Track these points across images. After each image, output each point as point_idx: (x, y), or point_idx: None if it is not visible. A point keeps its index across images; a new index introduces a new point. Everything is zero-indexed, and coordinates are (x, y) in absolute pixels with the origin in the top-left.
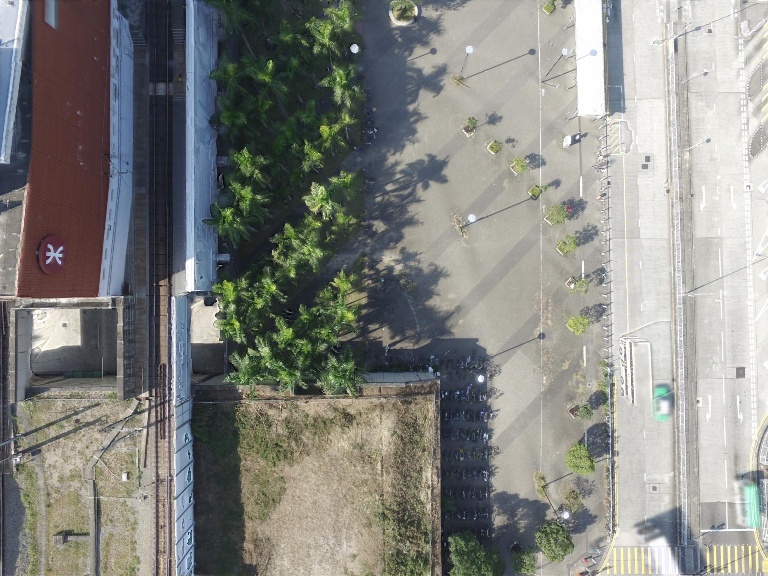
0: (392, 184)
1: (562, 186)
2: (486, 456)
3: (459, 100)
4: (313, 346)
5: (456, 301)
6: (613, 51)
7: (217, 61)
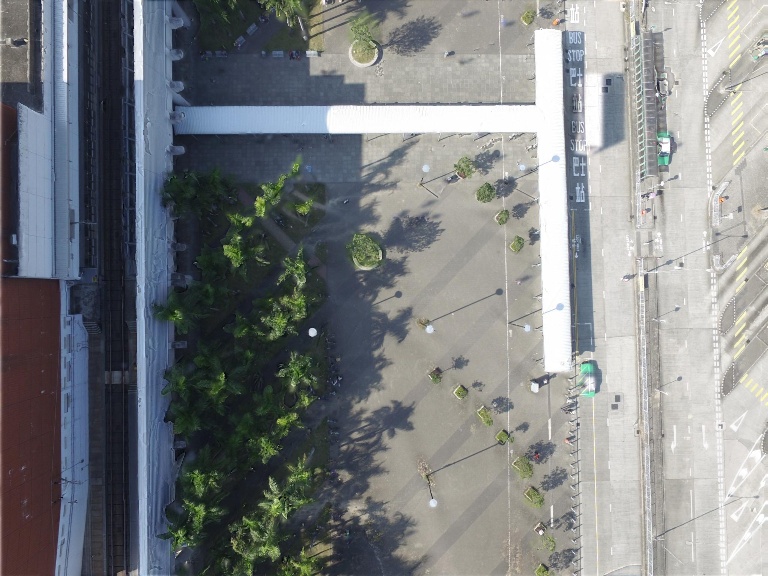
0: (357, 433)
1: (530, 429)
2: None
3: (425, 344)
4: None
5: (423, 550)
6: (582, 287)
7: (174, 343)
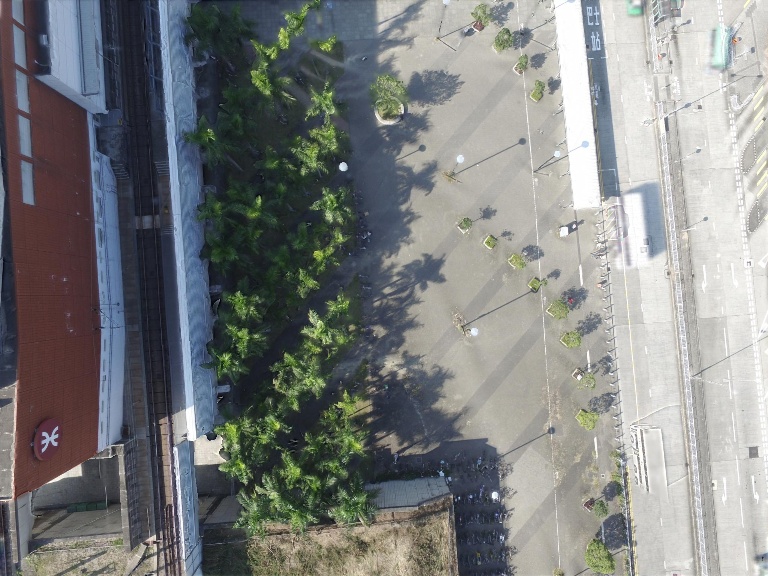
0: (390, 287)
1: (562, 276)
2: (504, 558)
3: (452, 196)
4: (322, 482)
5: (463, 402)
6: (604, 134)
7: (203, 187)
